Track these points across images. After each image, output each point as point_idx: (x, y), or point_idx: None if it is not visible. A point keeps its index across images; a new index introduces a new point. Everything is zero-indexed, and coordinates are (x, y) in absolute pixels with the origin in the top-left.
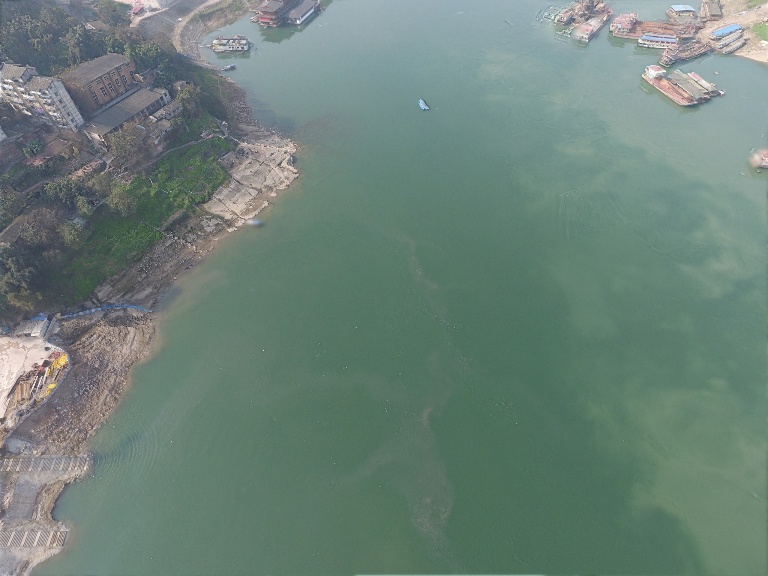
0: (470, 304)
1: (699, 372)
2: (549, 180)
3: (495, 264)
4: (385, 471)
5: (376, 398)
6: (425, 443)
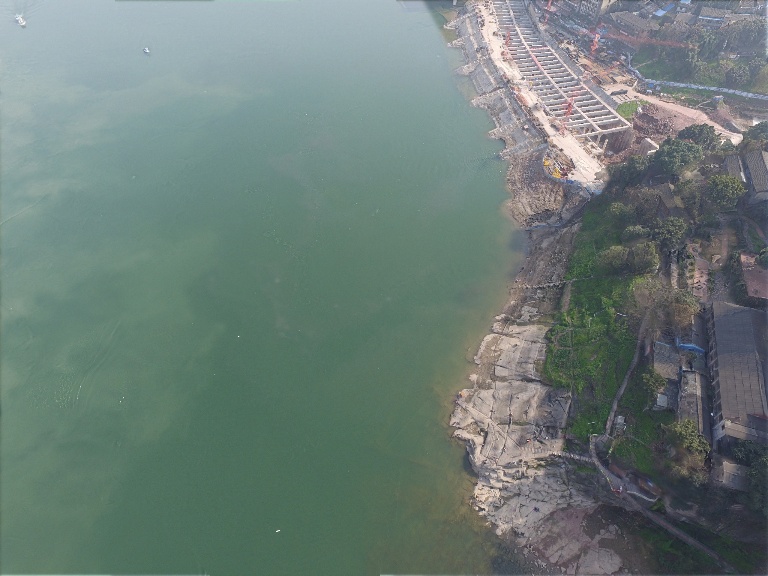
0: (251, 251)
1: None
2: (67, 446)
3: (212, 291)
4: (330, 166)
5: (334, 193)
6: (305, 173)
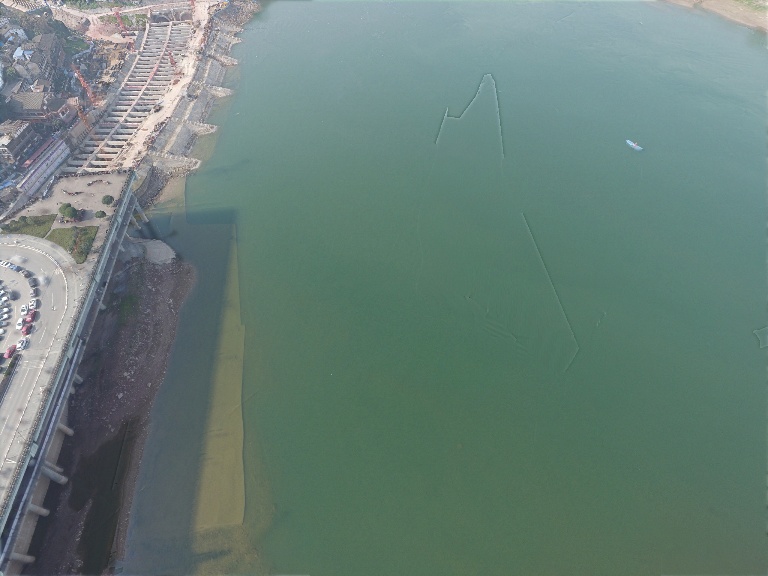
0: None
1: (494, 12)
2: None
3: None
4: (361, 28)
5: (357, 16)
6: None
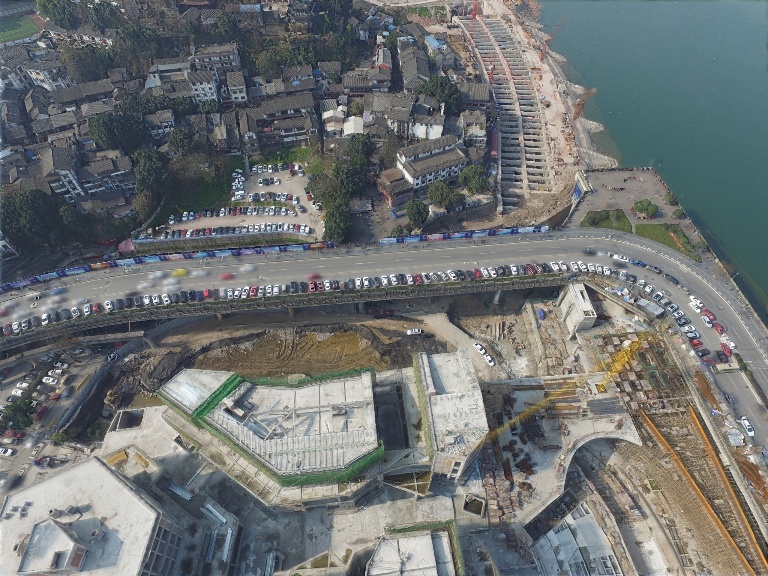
0: None
1: None
2: None
3: None
4: (663, 30)
5: (649, 17)
6: None
